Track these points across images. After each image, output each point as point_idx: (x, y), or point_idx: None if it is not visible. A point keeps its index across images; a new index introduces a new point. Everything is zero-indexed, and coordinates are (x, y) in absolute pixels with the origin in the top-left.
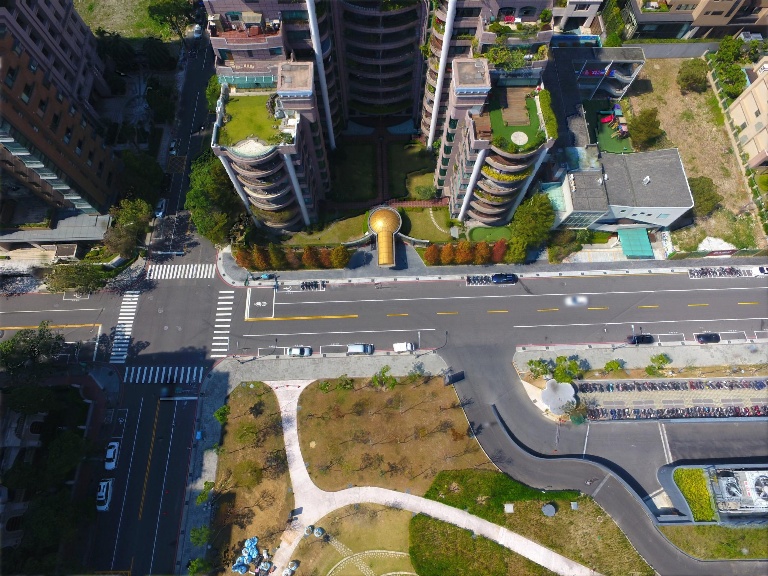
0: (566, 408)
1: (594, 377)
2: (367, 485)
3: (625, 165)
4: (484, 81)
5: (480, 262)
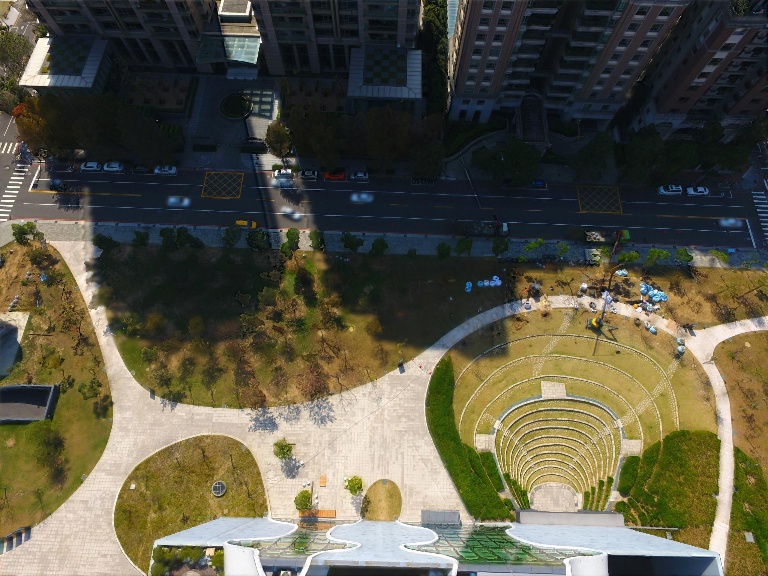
0: None
1: None
2: (729, 393)
3: None
4: None
5: None
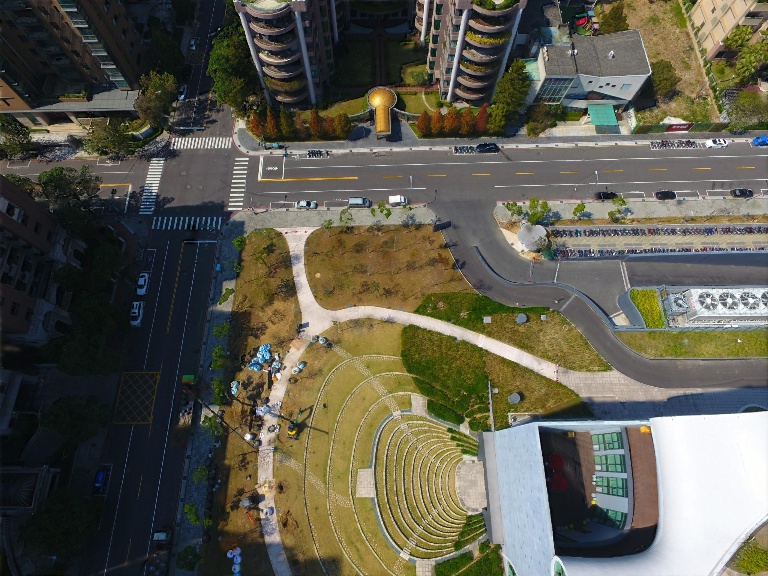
0: (539, 244)
1: (564, 224)
2: (365, 305)
3: (593, 45)
4: None
5: (466, 130)
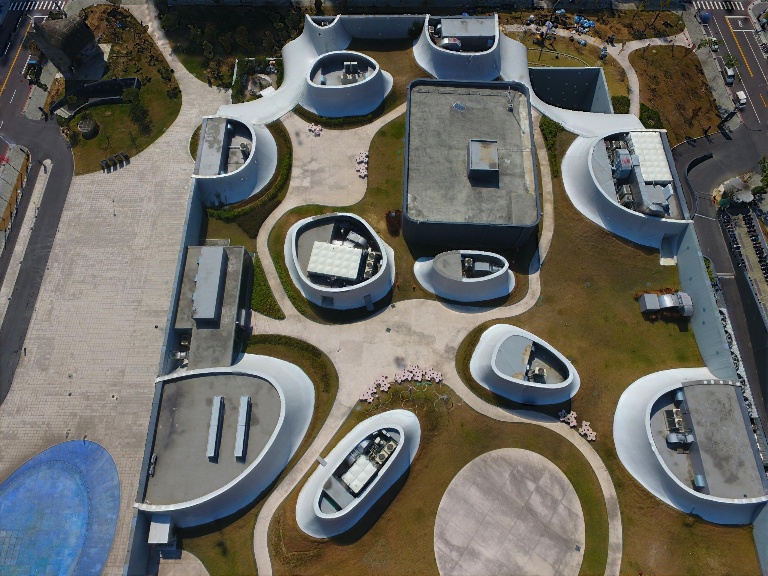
0: None
1: (761, 225)
2: (638, 77)
3: None
4: None
5: None
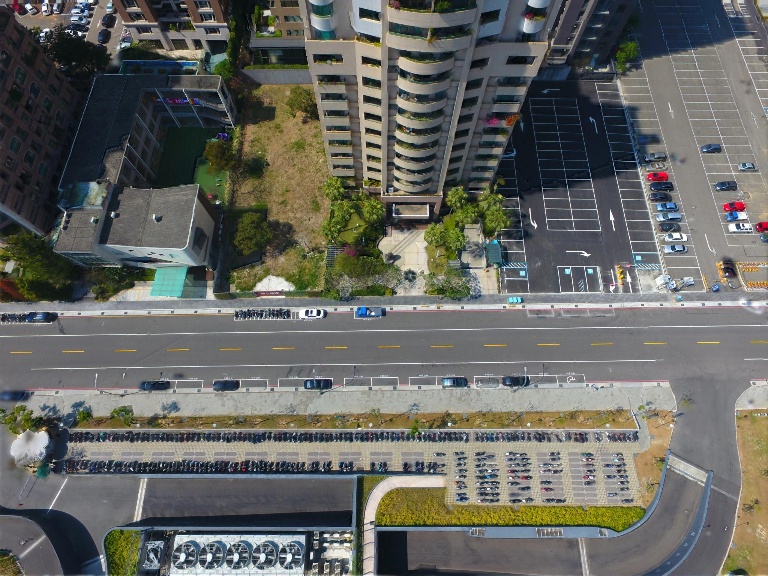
0: (31, 460)
1: (87, 426)
2: None
3: (149, 201)
4: None
5: (0, 300)
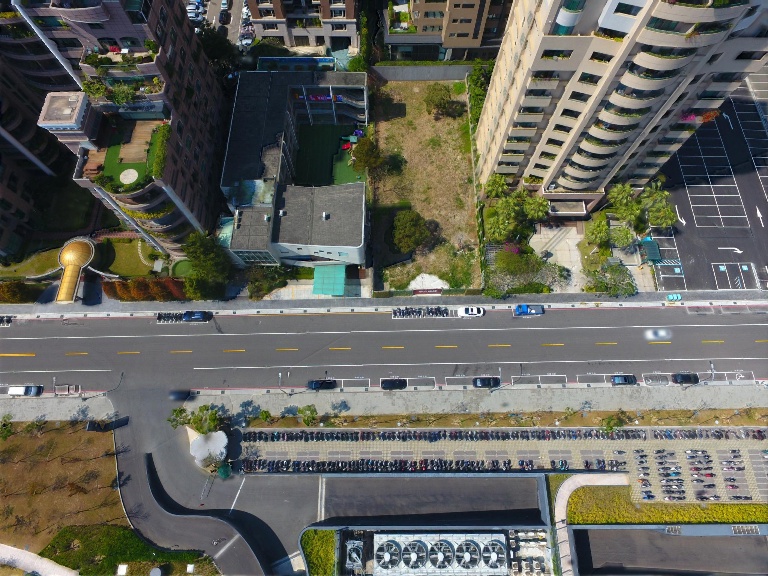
0: (212, 460)
1: (260, 425)
2: None
3: (312, 199)
4: (71, 117)
5: None
